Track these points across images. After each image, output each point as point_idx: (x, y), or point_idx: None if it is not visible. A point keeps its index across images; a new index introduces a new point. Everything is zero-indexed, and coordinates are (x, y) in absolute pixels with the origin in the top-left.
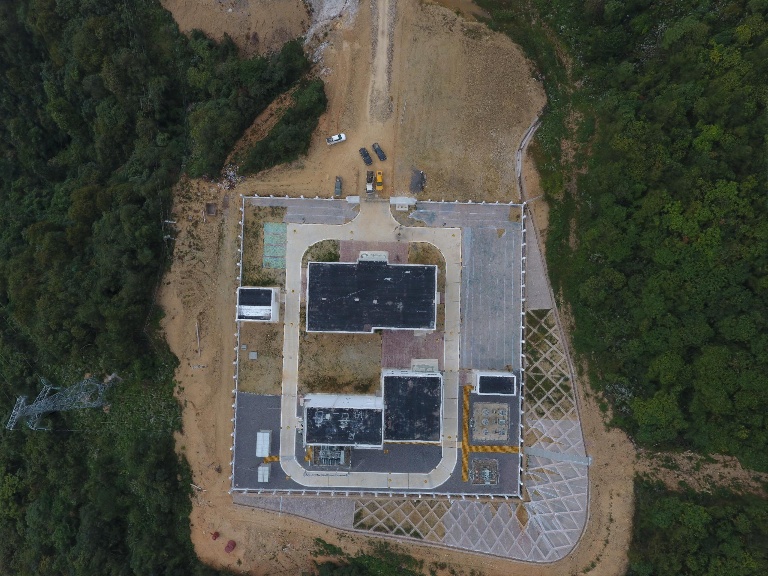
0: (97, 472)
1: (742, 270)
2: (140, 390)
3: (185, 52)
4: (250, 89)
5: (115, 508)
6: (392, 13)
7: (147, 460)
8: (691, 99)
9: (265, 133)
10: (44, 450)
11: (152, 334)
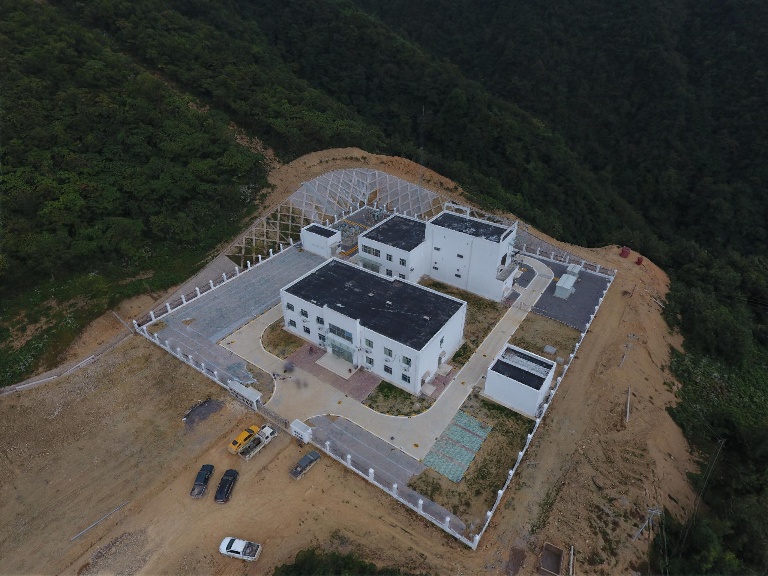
0: None
1: None
2: None
3: None
4: None
5: (767, 324)
6: None
7: None
8: None
9: None
10: None
11: None
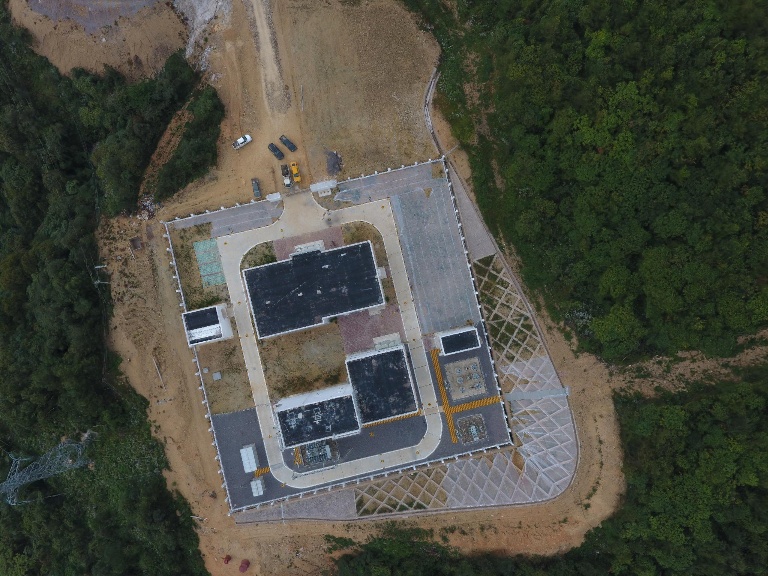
0: (97, 529)
1: (661, 166)
2: (118, 439)
3: (72, 94)
4: (144, 114)
5: (124, 559)
6: (265, 1)
7: (139, 505)
8: (575, 10)
9: (171, 154)
10: (42, 522)
11: (114, 382)
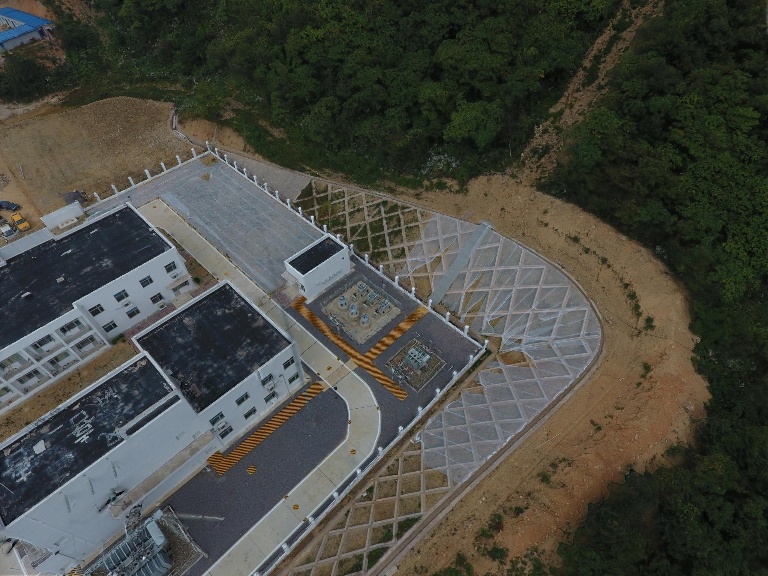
0: None
1: (392, 9)
2: None
3: None
4: None
5: None
6: None
7: None
8: None
9: None
10: None
11: None
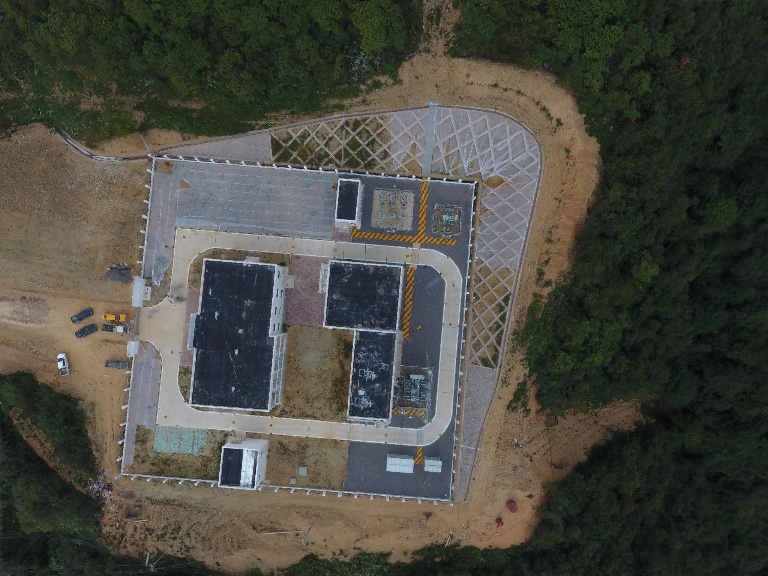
0: None
1: None
2: None
3: None
4: None
5: None
6: None
7: None
8: None
9: None
10: None
11: None
